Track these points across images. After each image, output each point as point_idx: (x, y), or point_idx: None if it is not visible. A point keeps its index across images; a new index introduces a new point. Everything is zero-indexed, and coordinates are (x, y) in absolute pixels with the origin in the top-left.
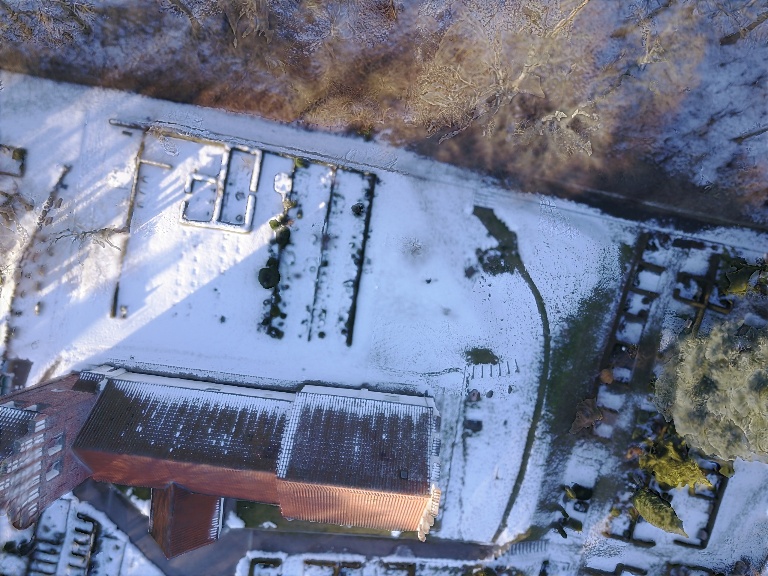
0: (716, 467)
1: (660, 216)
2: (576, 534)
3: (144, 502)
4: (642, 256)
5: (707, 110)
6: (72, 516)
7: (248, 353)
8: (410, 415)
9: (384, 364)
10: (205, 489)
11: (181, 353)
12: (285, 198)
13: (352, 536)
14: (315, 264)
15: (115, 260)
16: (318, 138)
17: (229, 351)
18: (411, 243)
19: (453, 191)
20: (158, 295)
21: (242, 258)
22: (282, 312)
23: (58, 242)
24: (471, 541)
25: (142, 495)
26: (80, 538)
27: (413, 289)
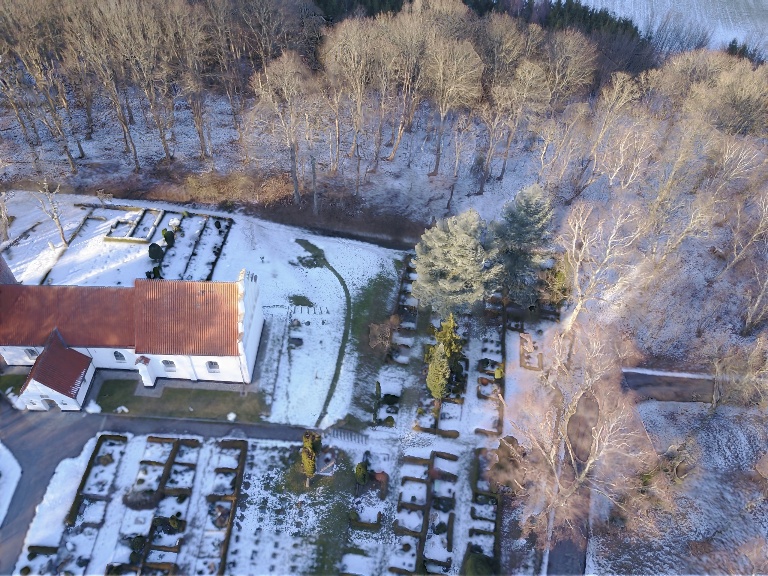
0: (493, 378)
1: None
2: (391, 430)
3: None
4: (409, 265)
5: (426, 196)
6: None
7: None
8: None
9: None
10: (79, 335)
11: None
12: None
13: (193, 421)
14: (188, 255)
15: (53, 259)
16: (200, 212)
17: None
18: None
19: (283, 233)
20: (77, 274)
21: (140, 255)
22: None
23: (18, 254)
24: (297, 425)
25: None
26: None
27: (253, 266)
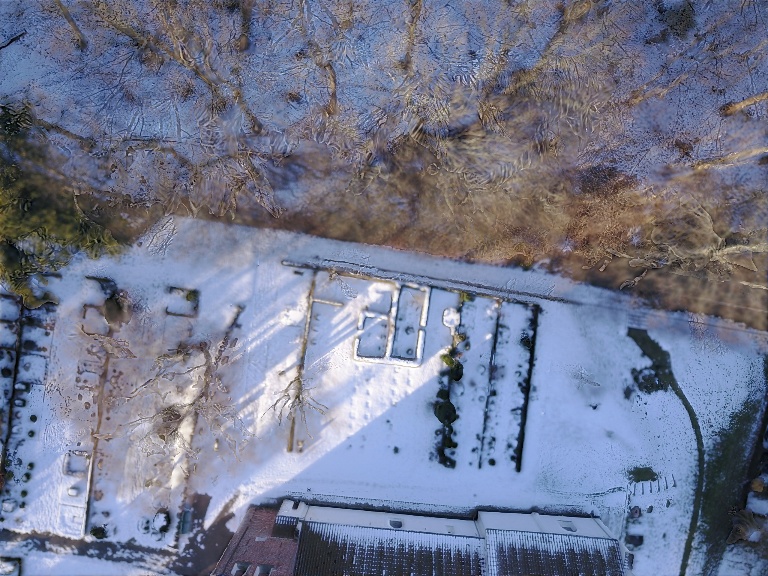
0: None
1: None
2: None
3: None
4: None
5: None
6: None
7: (421, 482)
8: (598, 550)
9: (551, 487)
10: None
11: (356, 484)
12: (455, 332)
13: None
14: (484, 394)
15: None
16: (480, 269)
17: (403, 480)
18: (579, 373)
19: (608, 314)
20: (332, 428)
21: (413, 390)
22: (454, 441)
23: (234, 380)
24: None
25: None
26: None
27: (577, 414)
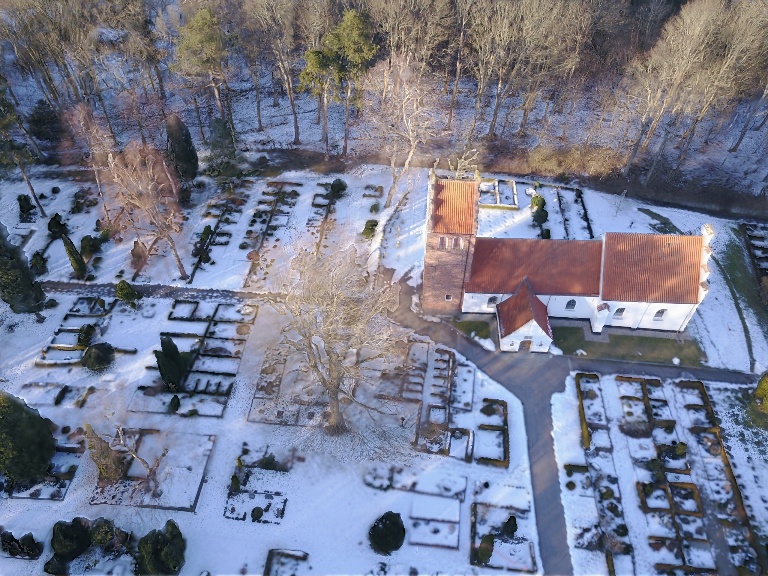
0: None
1: (745, 218)
2: None
3: (485, 340)
4: (747, 233)
5: (740, 170)
6: (431, 354)
7: None
8: None
9: None
10: (546, 284)
11: None
12: None
13: (644, 364)
14: (561, 220)
15: None
16: None
17: None
18: None
19: (622, 203)
20: None
21: (517, 220)
22: None
23: (406, 218)
24: (735, 370)
25: (482, 336)
26: (439, 367)
27: (623, 231)
